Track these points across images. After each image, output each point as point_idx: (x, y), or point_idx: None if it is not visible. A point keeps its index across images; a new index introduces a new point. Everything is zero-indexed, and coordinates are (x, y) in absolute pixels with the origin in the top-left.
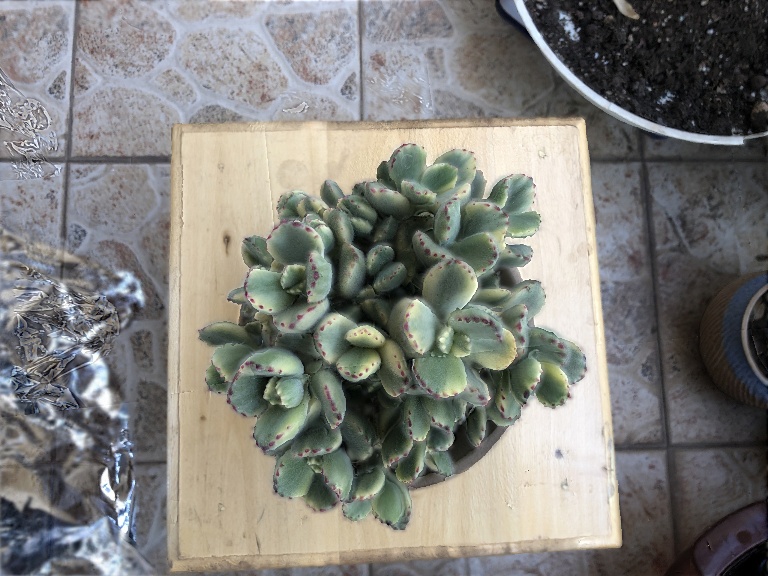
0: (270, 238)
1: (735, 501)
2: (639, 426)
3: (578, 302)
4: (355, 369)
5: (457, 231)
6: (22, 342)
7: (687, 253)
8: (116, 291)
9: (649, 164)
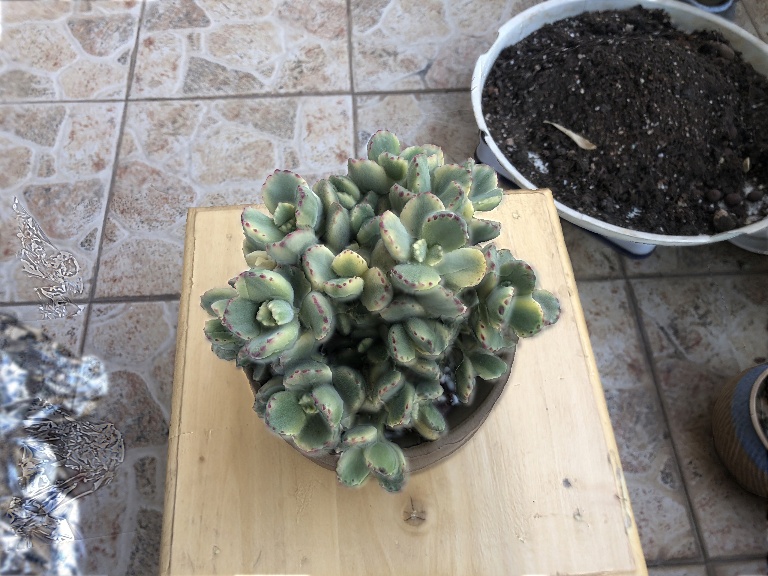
0: (265, 184)
1: None
2: (670, 539)
3: (565, 336)
4: (339, 281)
5: (427, 187)
6: (25, 472)
7: (685, 359)
8: (124, 419)
9: (632, 281)
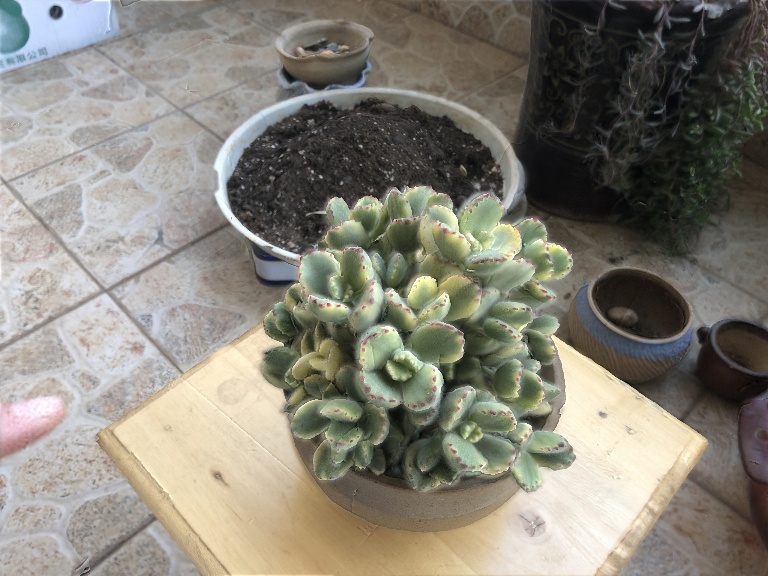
0: (301, 274)
1: (732, 449)
2: None
3: None
4: (438, 302)
5: None
6: None
7: None
8: None
9: None
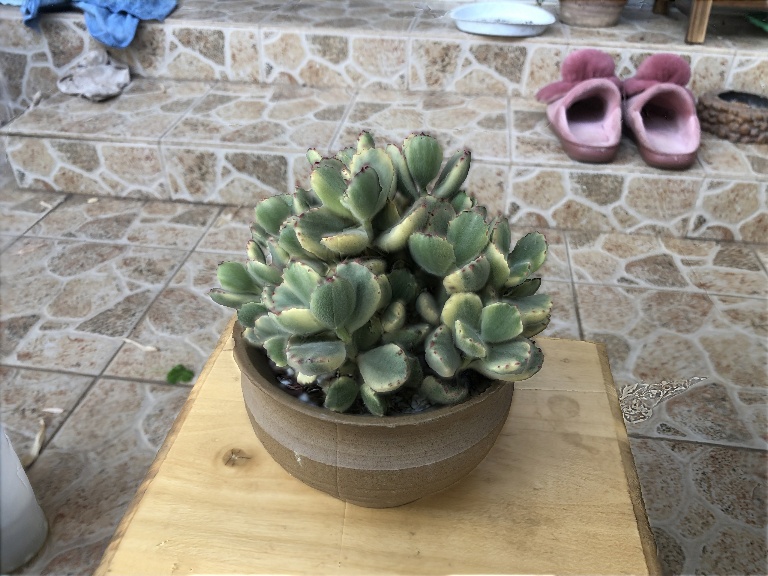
0: None
1: None
2: None
3: None
4: None
5: (459, 249)
6: None
7: None
8: None
9: None
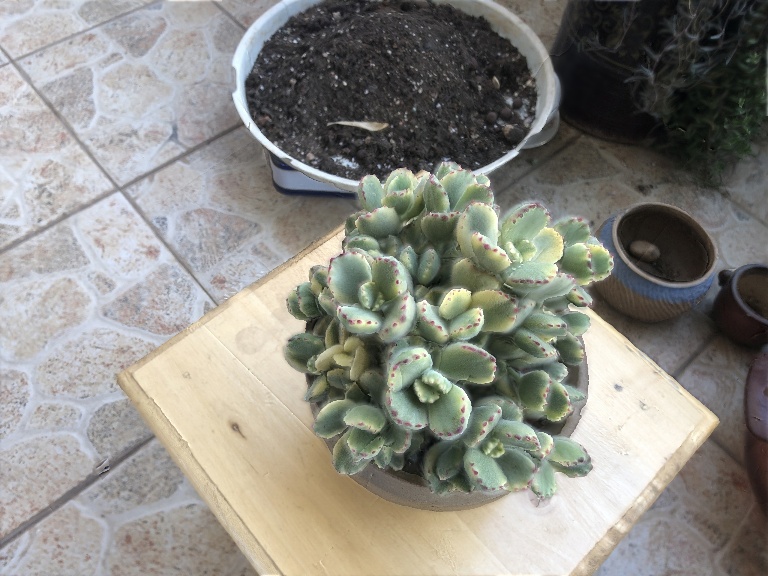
0: (331, 279)
1: (735, 393)
2: None
3: None
4: (471, 321)
5: None
6: None
7: None
8: None
9: None
